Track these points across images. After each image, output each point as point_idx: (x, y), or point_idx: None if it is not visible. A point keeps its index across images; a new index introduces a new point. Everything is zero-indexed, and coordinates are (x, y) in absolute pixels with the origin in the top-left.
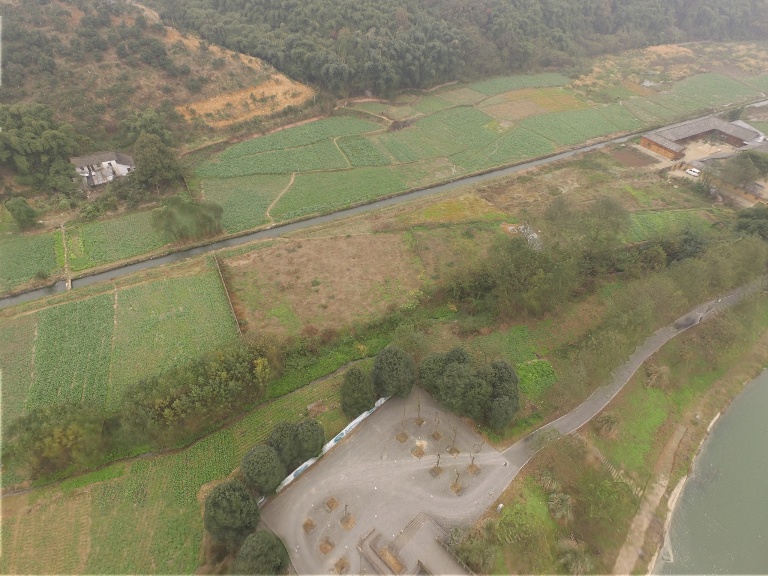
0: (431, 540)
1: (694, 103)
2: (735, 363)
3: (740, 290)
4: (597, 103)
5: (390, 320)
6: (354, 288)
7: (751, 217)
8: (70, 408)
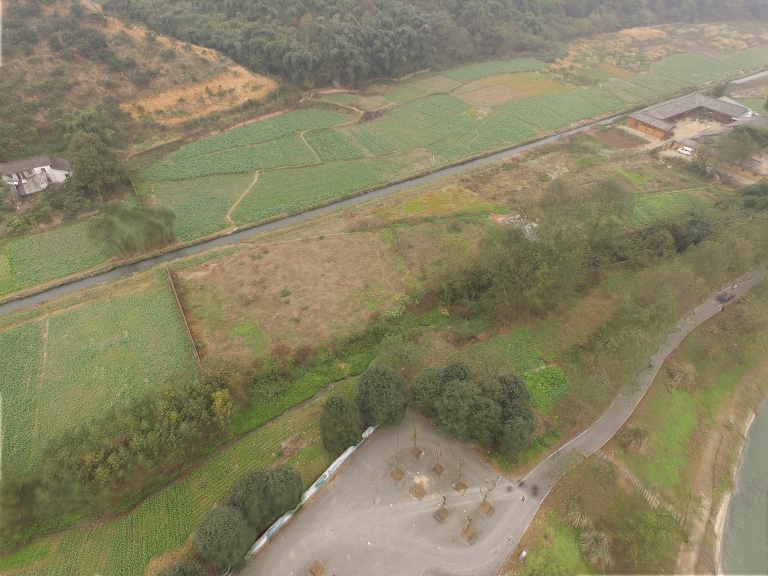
0: None
1: (674, 82)
2: (762, 355)
3: (759, 273)
4: (576, 86)
5: (374, 331)
6: (330, 296)
7: (757, 194)
8: None
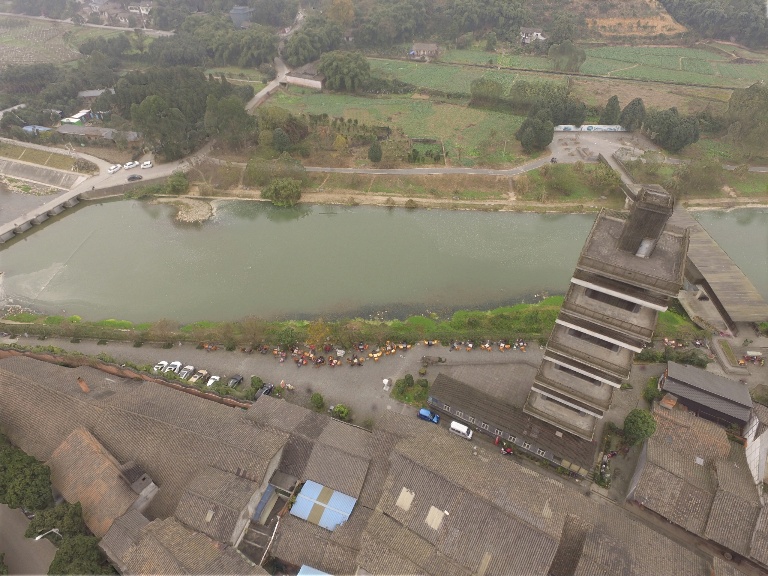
0: None
1: None
2: None
3: None
4: None
5: None
6: None
7: None
8: (495, 81)
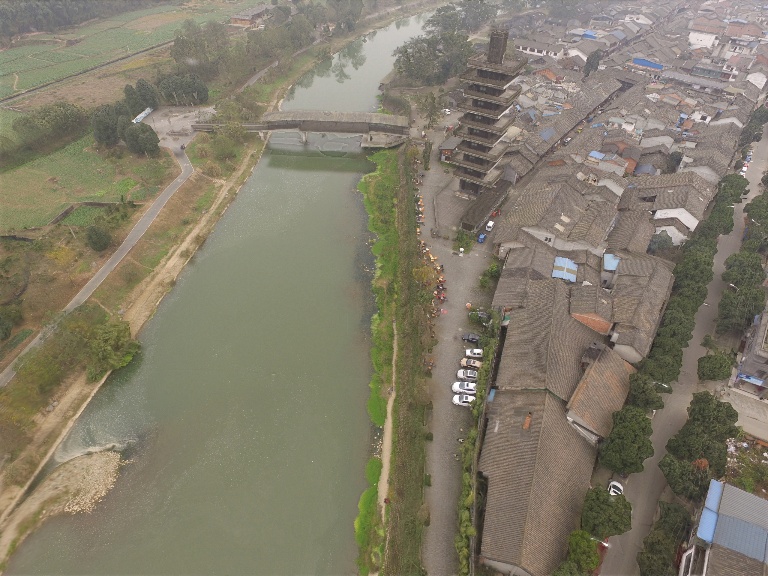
0: None
1: (256, 5)
2: None
3: None
4: (201, 14)
5: None
6: (105, 94)
7: None
8: None
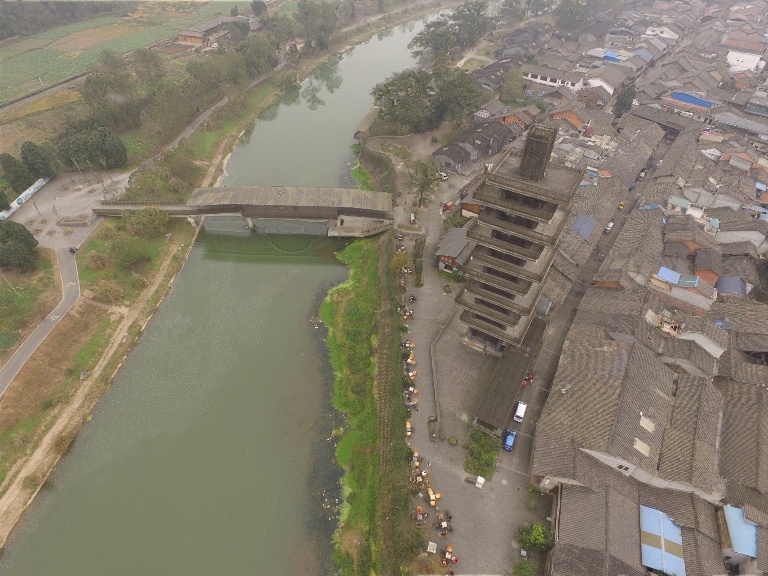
0: (98, 206)
1: None
2: (249, 112)
3: None
4: (147, 27)
5: None
6: None
7: (240, 51)
8: None
